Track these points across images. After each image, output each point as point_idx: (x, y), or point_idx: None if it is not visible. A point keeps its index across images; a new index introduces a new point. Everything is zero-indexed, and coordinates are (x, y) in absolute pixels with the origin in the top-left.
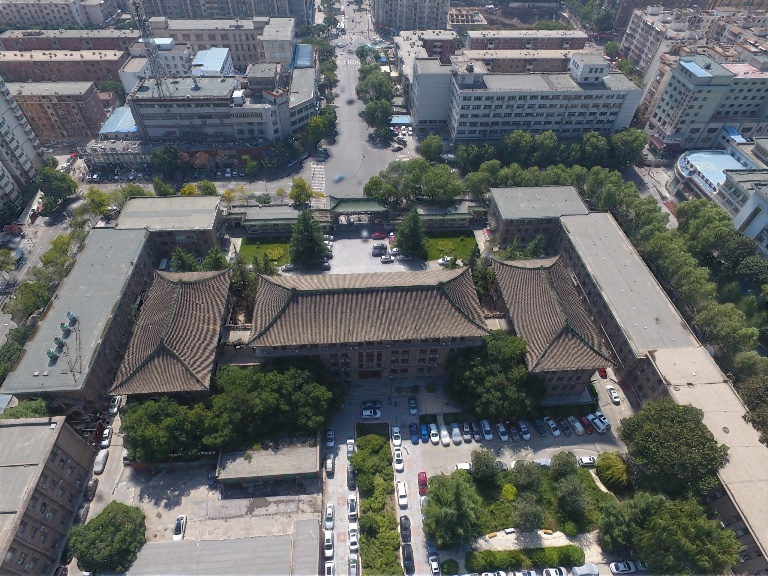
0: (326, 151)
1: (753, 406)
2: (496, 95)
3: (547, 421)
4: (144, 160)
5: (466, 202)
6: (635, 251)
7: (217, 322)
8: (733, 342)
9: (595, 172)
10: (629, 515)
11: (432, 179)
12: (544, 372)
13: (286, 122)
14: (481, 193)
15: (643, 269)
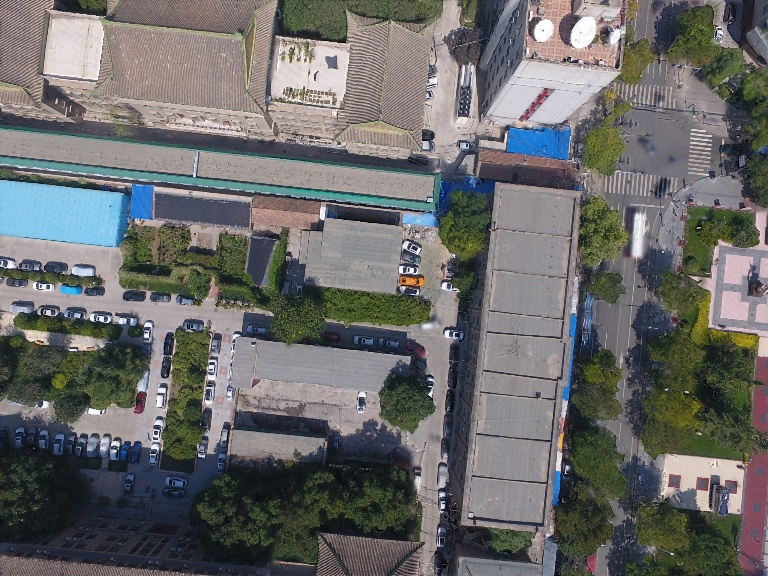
0: None
1: None
2: None
3: None
4: None
5: None
6: None
7: None
8: None
9: None
10: None
11: None
12: None
13: None
14: None
15: None
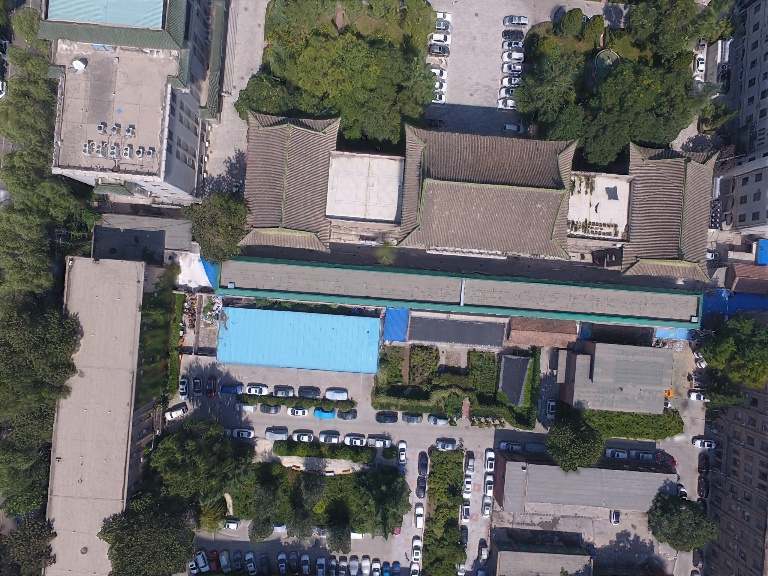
0: None
1: (35, 574)
2: None
3: (254, 571)
4: None
5: None
6: None
7: None
8: None
9: None
10: None
11: None
12: None
13: None
14: None
15: None
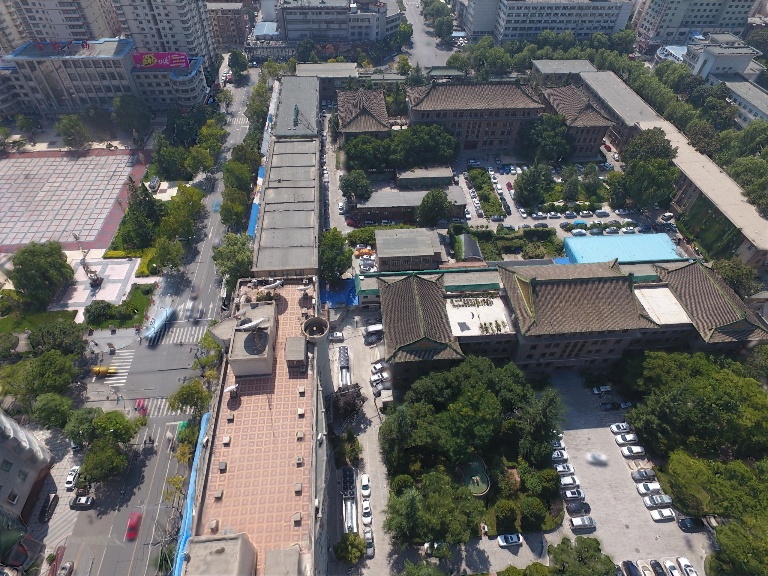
0: (408, 52)
1: (693, 139)
2: (532, 5)
3: (577, 165)
4: (287, 53)
5: (515, 73)
6: (628, 87)
7: (384, 108)
8: (685, 119)
9: (601, 52)
10: (625, 175)
11: (493, 54)
12: (576, 132)
13: (383, 28)
14: (524, 69)
15: (633, 94)
